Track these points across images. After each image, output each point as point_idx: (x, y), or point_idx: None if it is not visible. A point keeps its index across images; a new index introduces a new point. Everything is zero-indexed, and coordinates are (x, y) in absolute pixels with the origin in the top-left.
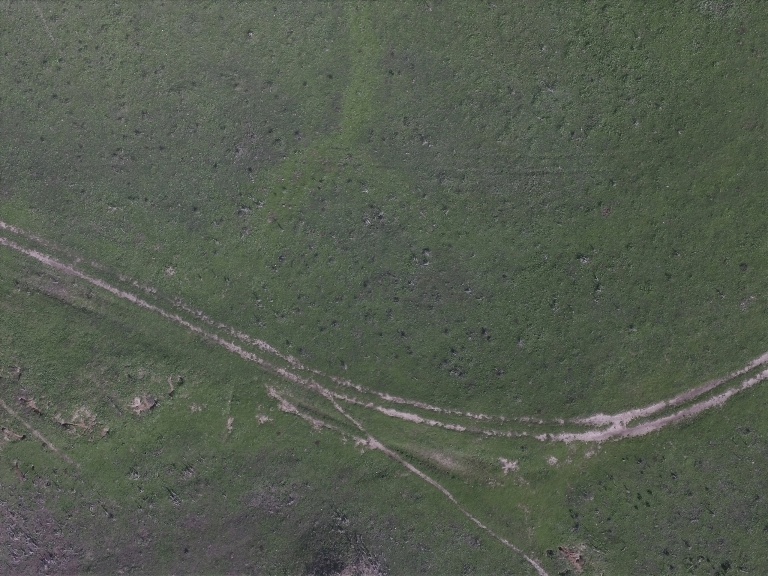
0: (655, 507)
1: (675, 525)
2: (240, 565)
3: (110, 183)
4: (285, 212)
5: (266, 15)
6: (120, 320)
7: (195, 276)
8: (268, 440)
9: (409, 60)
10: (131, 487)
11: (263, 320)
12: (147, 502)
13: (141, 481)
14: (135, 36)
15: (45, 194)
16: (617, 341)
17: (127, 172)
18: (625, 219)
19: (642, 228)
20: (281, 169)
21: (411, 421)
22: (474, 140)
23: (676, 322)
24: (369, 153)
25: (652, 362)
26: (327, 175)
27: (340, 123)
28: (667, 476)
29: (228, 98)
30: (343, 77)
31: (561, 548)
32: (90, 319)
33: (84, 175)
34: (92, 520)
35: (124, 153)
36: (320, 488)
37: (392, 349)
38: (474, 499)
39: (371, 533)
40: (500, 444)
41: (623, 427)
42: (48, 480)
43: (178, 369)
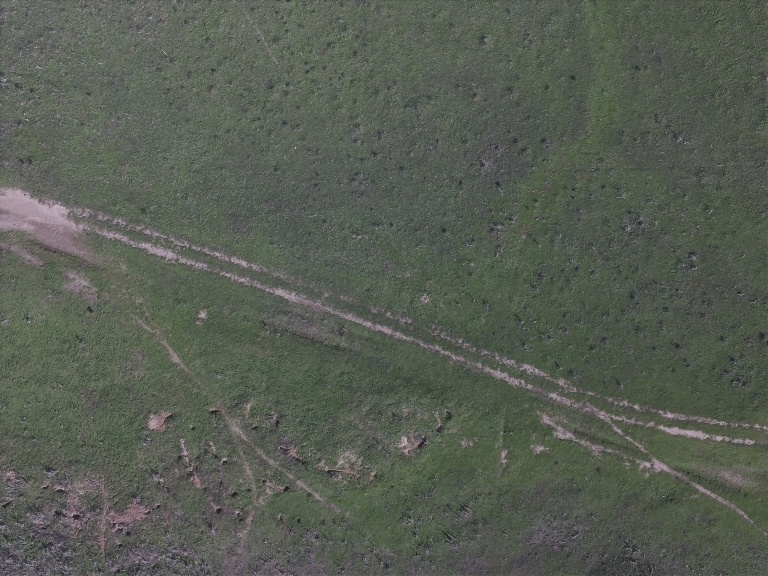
0: None
1: None
2: None
3: (351, 210)
4: (539, 226)
5: (499, 18)
6: (376, 355)
7: (452, 302)
8: (546, 471)
9: (655, 53)
10: (404, 533)
11: (528, 343)
12: (423, 548)
13: (414, 525)
14: (363, 52)
15: (285, 228)
16: None
17: (368, 197)
18: None
19: None
20: (530, 180)
21: (696, 438)
22: (731, 132)
23: None
24: (621, 156)
25: None
26: (579, 183)
27: (587, 126)
28: None
29: (467, 110)
30: (587, 77)
31: None
32: (345, 357)
33: (324, 204)
34: (366, 571)
35: (363, 177)
36: (605, 518)
37: (667, 363)
38: None
39: (664, 562)
40: None
41: None
42: (316, 532)
43: (445, 403)
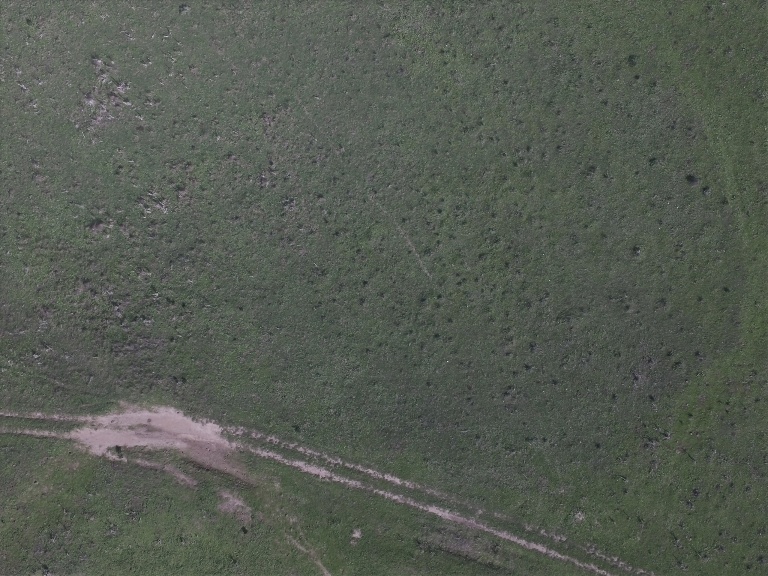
0: None
1: None
2: None
3: (504, 425)
4: (694, 440)
5: (651, 229)
6: (531, 574)
7: (607, 519)
8: None
9: None
10: None
11: (685, 562)
12: None
13: None
14: (515, 263)
15: (438, 443)
16: None
17: (521, 411)
18: None
19: None
20: (684, 394)
21: None
22: None
23: None
24: None
25: None
26: (733, 396)
27: (740, 338)
28: None
29: (620, 322)
30: (740, 289)
31: None
32: (499, 575)
33: (476, 419)
34: None
35: (516, 391)
36: None
37: None
38: None
39: None
40: None
41: None
42: None
43: None
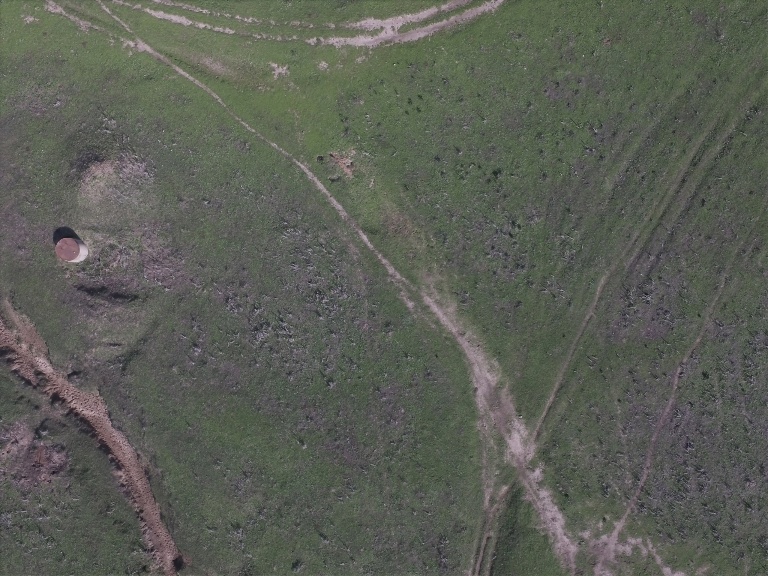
0: (426, 113)
1: (447, 132)
2: (5, 165)
3: None
4: None
5: None
6: None
7: None
8: (34, 40)
9: None
10: None
11: None
12: None
13: None
14: None
15: None
16: None
17: None
18: None
19: None
20: None
21: (180, 24)
22: None
23: None
24: None
25: None
26: None
27: None
28: (438, 81)
29: None
30: None
31: (332, 155)
32: None
33: None
34: None
35: None
36: (87, 89)
37: None
38: (243, 102)
39: (139, 135)
40: (269, 47)
41: (394, 32)
42: None
43: None
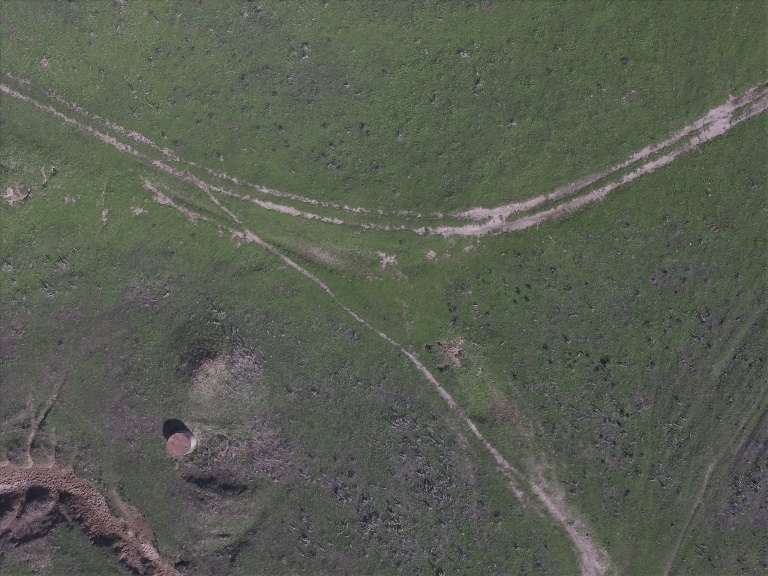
0: (534, 302)
1: (554, 320)
2: (115, 357)
3: None
4: (161, 4)
5: None
6: None
7: (69, 67)
8: (143, 232)
9: None
10: (4, 278)
11: (138, 111)
12: (20, 293)
13: (14, 273)
14: None
15: None
16: (497, 135)
17: None
18: (506, 14)
19: (523, 23)
20: None
21: (288, 214)
22: None
23: (556, 116)
24: None
25: (532, 156)
26: None
27: None
28: (546, 270)
29: None
30: None
31: (440, 343)
32: None
33: None
34: None
35: None
36: (196, 281)
37: (269, 142)
38: (352, 293)
39: (247, 326)
40: (378, 237)
41: (502, 221)
42: None
43: (51, 159)
